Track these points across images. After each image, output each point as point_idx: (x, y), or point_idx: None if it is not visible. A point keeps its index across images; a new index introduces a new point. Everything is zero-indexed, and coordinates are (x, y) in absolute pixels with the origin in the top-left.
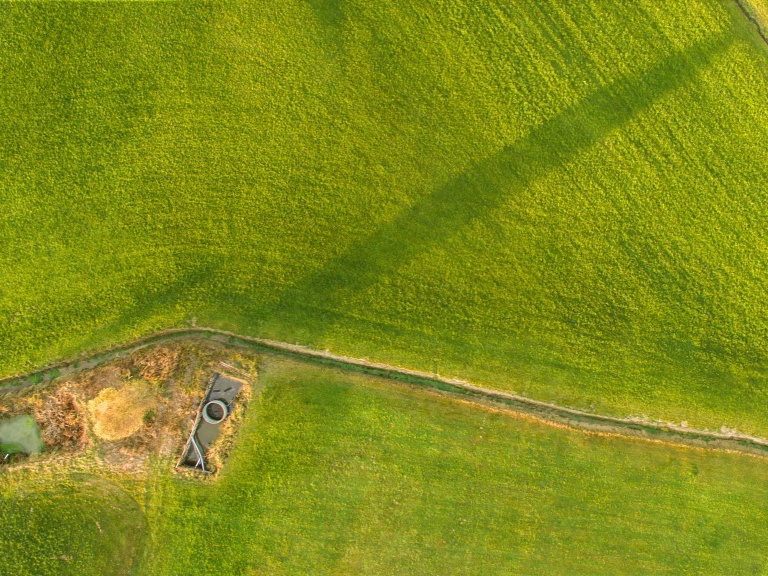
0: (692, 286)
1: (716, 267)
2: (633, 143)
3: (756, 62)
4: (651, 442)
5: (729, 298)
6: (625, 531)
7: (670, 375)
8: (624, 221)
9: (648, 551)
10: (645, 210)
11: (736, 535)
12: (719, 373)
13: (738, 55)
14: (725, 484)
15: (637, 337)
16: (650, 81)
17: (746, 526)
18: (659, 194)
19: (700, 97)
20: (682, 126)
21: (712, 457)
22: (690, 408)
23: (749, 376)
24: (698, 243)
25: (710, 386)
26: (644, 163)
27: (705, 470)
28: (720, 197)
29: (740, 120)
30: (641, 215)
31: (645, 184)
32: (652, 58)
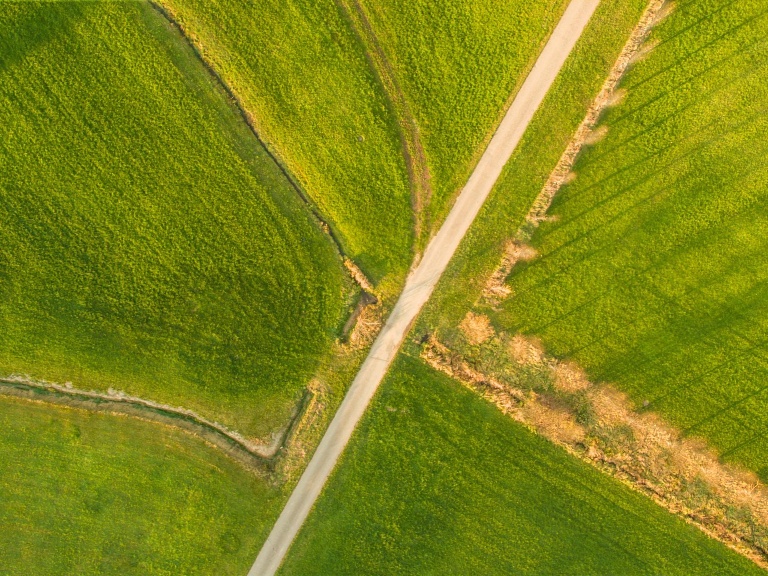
0: (75, 244)
1: (100, 225)
2: (7, 96)
3: (130, 15)
4: (33, 402)
5: (115, 257)
6: (3, 493)
7: (53, 334)
8: (2, 176)
9: (26, 514)
10: (23, 165)
11: (120, 500)
12: (106, 333)
13: (111, 7)
14: (109, 447)
15: (19, 295)
16: (22, 33)
17: (131, 491)
18: (37, 149)
19: (75, 50)
20: (57, 79)
21: (96, 419)
22: (75, 368)
23: (138, 337)
24: (80, 200)
25: (96, 346)
26: (20, 117)
27: (88, 432)
28: (101, 153)
29: (118, 74)
30: (19, 170)
31: (22, 138)
32: (23, 9)
